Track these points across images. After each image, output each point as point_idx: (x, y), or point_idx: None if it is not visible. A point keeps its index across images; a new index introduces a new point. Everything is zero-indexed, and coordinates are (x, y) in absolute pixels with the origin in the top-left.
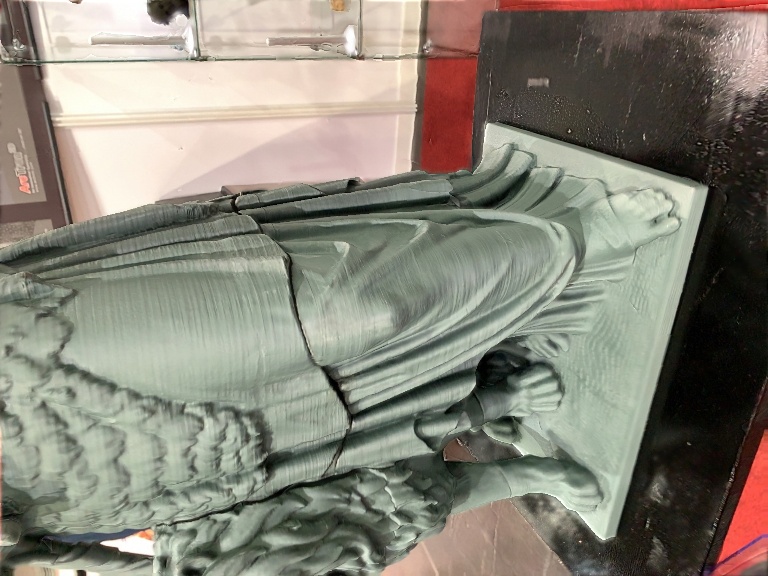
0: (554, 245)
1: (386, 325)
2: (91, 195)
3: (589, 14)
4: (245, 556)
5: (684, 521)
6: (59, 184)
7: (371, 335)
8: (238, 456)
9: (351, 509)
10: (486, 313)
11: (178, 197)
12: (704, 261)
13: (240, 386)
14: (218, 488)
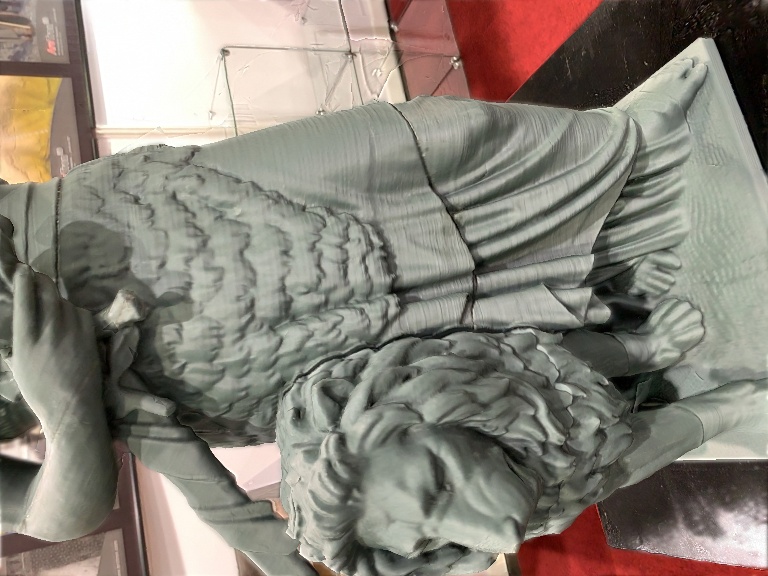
0: (608, 116)
1: (477, 112)
2: (163, 499)
3: (565, 44)
4: (393, 368)
5: None
6: (133, 487)
7: (467, 121)
8: (365, 265)
9: (505, 364)
10: (572, 167)
11: (249, 490)
12: (747, 88)
13: (356, 180)
14: (349, 308)
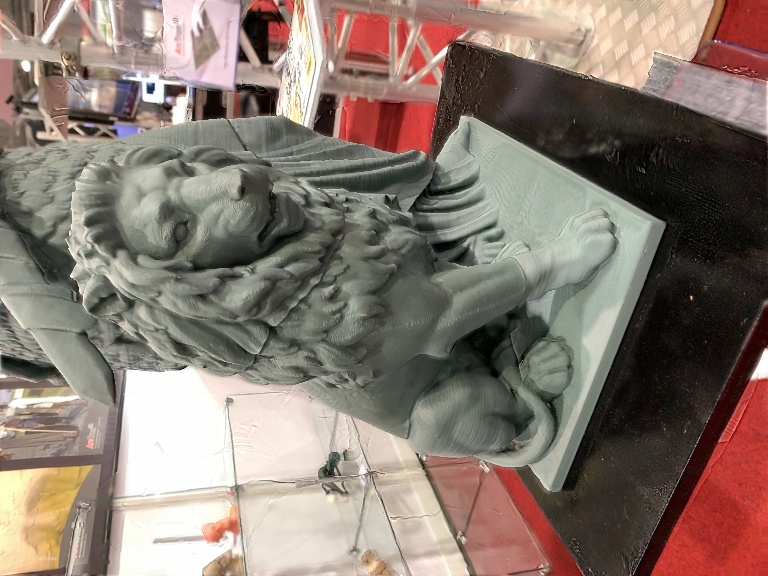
0: None
1: None
2: None
3: None
4: None
5: (628, 122)
6: None
7: None
8: None
9: None
10: None
11: None
12: None
13: (185, 139)
14: None
